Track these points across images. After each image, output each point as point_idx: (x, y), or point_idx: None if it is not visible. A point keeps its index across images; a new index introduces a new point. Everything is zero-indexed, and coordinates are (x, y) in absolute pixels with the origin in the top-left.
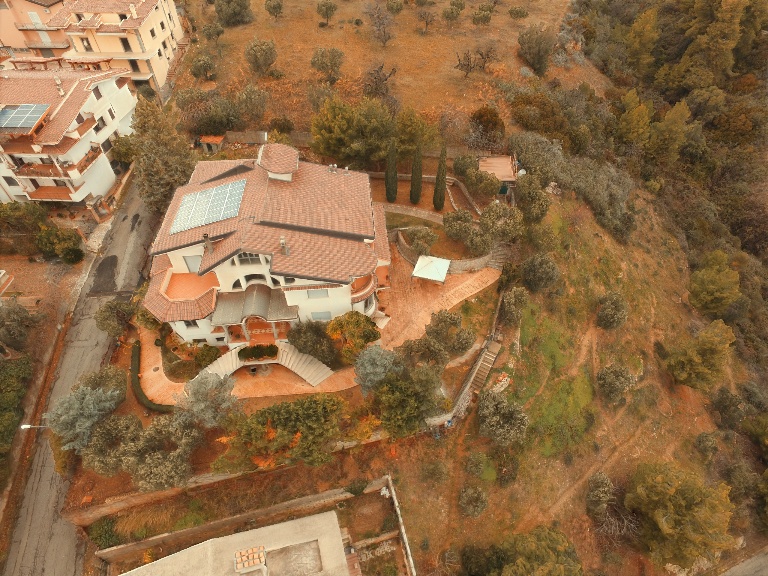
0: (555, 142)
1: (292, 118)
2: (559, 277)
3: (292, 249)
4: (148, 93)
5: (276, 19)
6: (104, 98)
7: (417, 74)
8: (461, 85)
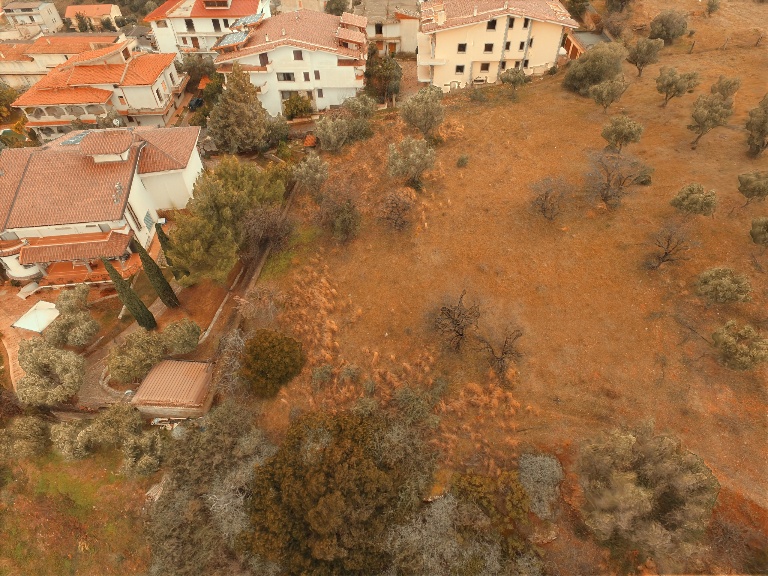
0: (232, 496)
1: (332, 174)
2: (2, 488)
3: (1, 177)
4: (389, 88)
5: (604, 110)
6: (305, 62)
7: (456, 267)
8: (431, 331)
